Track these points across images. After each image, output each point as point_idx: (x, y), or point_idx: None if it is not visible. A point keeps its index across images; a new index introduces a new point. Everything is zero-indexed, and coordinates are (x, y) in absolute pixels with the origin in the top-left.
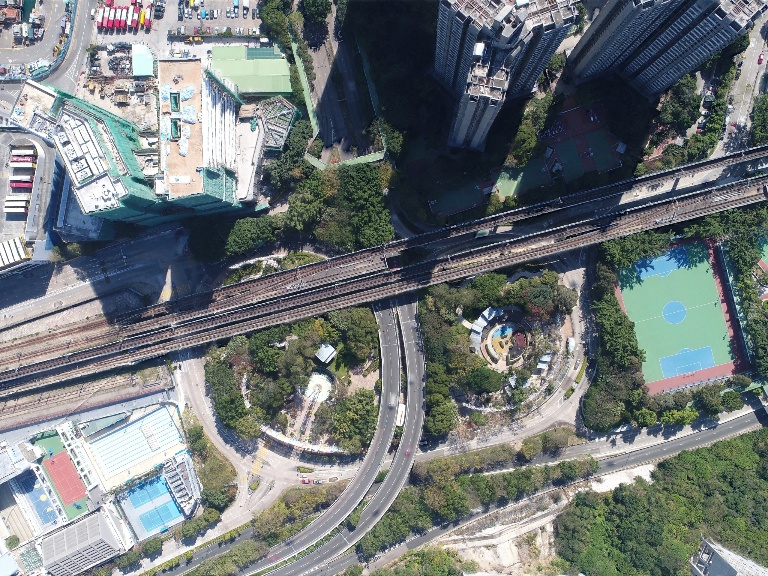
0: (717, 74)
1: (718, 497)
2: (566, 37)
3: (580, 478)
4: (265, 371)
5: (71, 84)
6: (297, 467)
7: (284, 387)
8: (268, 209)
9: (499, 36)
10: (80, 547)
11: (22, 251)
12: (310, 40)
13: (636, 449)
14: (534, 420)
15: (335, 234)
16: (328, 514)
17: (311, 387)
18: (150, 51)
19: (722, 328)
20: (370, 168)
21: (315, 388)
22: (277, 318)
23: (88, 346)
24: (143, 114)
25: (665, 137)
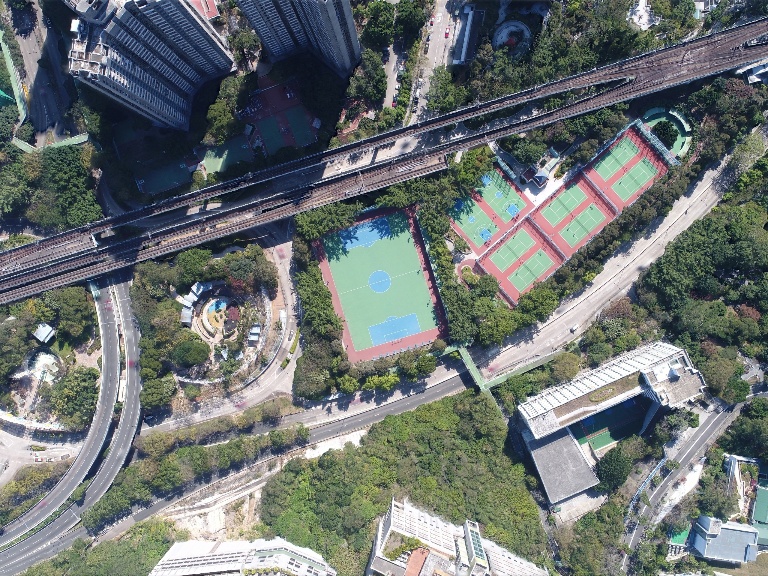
0: (405, 49)
1: (412, 458)
2: None
3: (297, 446)
4: None
5: None
6: (30, 446)
7: (2, 367)
8: None
9: None
10: None
11: None
12: (20, 27)
13: (349, 416)
14: (253, 391)
15: (45, 216)
16: (57, 490)
17: None
18: None
19: (425, 295)
20: (72, 150)
21: (38, 367)
22: None
23: None
24: None
25: (356, 111)
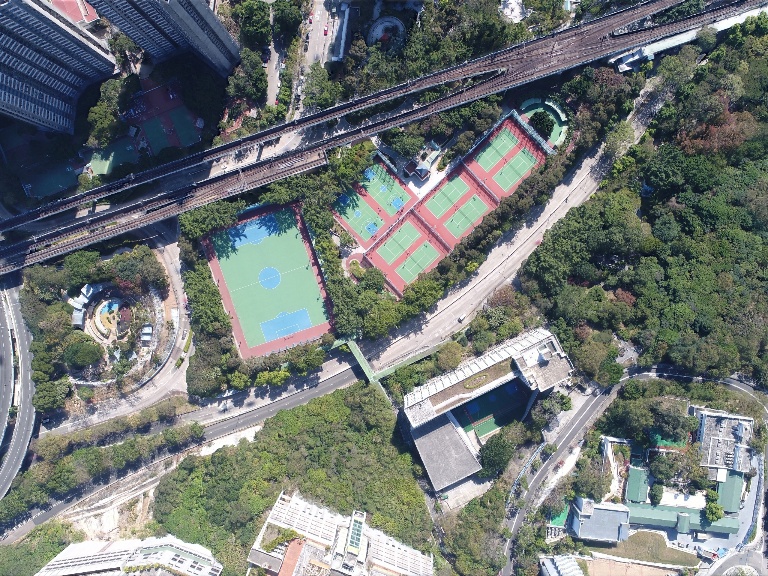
0: (285, 47)
1: (302, 451)
2: None
3: (194, 444)
4: None
5: None
6: None
7: None
8: None
9: None
10: None
11: None
12: None
13: (244, 412)
14: (149, 391)
15: None
16: None
17: None
18: None
19: (315, 290)
20: None
21: None
22: None
23: None
24: None
25: (237, 110)
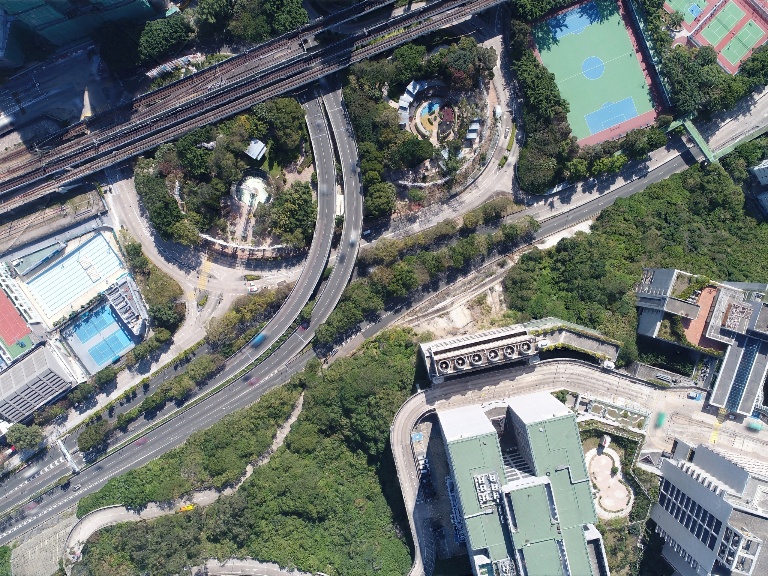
0: None
1: (654, 231)
2: None
3: (524, 244)
4: (196, 173)
5: None
6: (244, 276)
7: (218, 187)
8: None
9: None
10: (28, 380)
11: None
12: None
13: (574, 207)
14: (472, 194)
15: (249, 25)
16: (280, 315)
17: (247, 192)
18: None
19: (640, 77)
20: None
21: None
22: (202, 120)
23: None
24: None
25: None
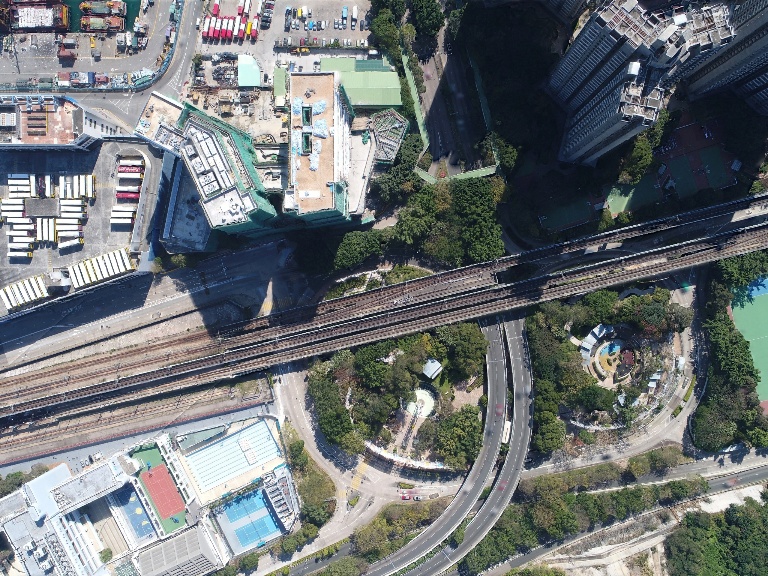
0: None
1: None
2: None
3: (687, 498)
4: (371, 386)
5: (174, 94)
6: (397, 483)
7: (390, 402)
8: (373, 222)
9: (658, 56)
10: (180, 562)
11: (128, 262)
12: (419, 53)
13: (745, 469)
14: (640, 438)
15: (444, 249)
16: (430, 531)
17: (413, 402)
18: (256, 62)
19: None
20: (482, 183)
21: (419, 404)
22: (383, 333)
23: (188, 358)
24: (247, 125)
25: None
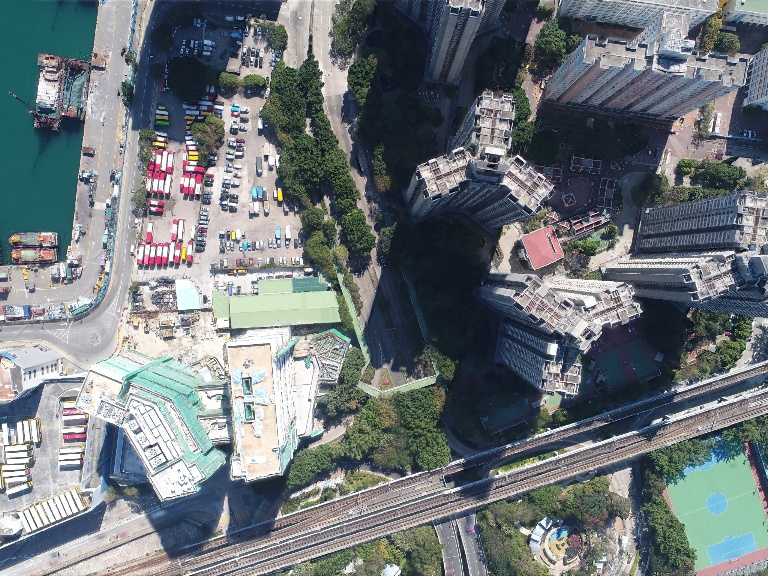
0: None
1: None
2: (599, 252)
3: None
4: None
5: (114, 320)
6: None
7: None
8: (322, 432)
9: (573, 341)
10: None
11: (80, 503)
12: (353, 266)
13: None
14: None
15: (393, 458)
16: None
17: None
18: (194, 285)
19: (761, 515)
20: (424, 395)
21: None
22: (341, 542)
23: None
24: (190, 346)
25: (699, 346)
